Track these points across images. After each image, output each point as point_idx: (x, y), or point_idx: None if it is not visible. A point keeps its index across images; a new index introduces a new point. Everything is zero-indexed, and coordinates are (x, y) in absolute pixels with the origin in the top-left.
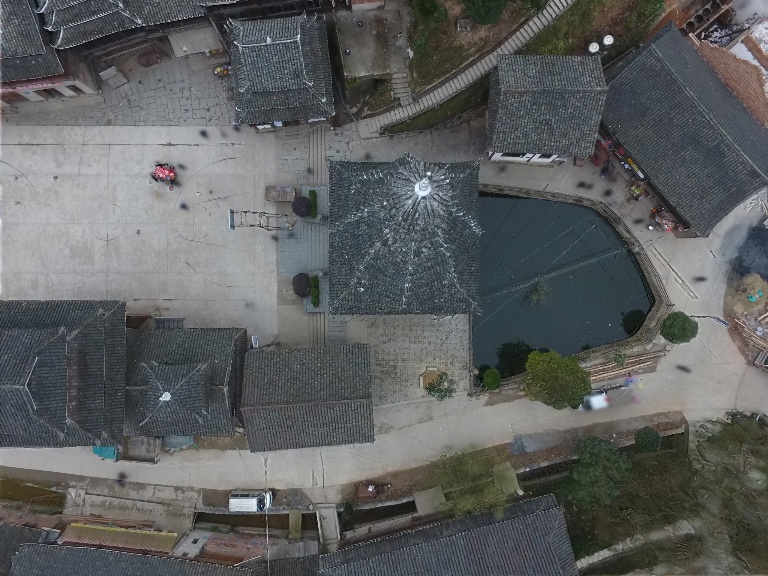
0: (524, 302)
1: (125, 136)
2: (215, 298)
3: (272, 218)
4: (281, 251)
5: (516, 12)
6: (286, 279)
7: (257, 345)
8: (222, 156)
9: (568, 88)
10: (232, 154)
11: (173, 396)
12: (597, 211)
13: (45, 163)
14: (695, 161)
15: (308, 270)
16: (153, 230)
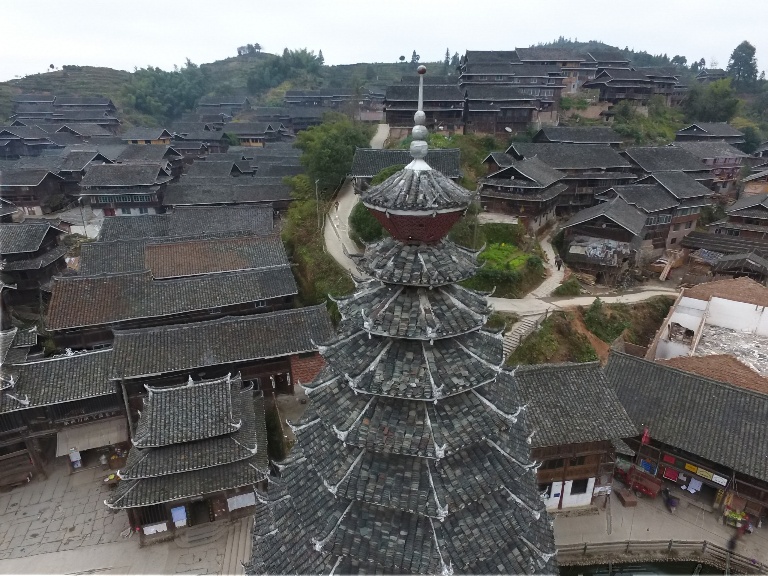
0: None
1: None
2: None
3: None
4: None
5: None
6: None
7: None
8: None
9: (556, 366)
10: None
11: None
12: (710, 566)
13: None
14: (767, 433)
15: None
16: None
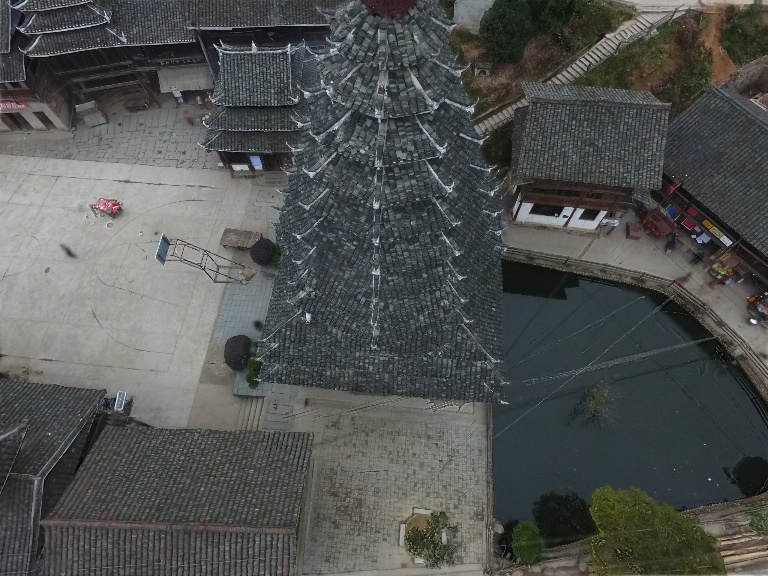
0: (573, 421)
1: (80, 170)
2: (113, 364)
3: (224, 268)
4: (224, 309)
5: (542, 64)
6: (221, 347)
7: (121, 408)
8: (184, 197)
9: None
10: (196, 196)
11: None
12: (667, 297)
13: None
14: None
15: (255, 337)
16: (67, 269)
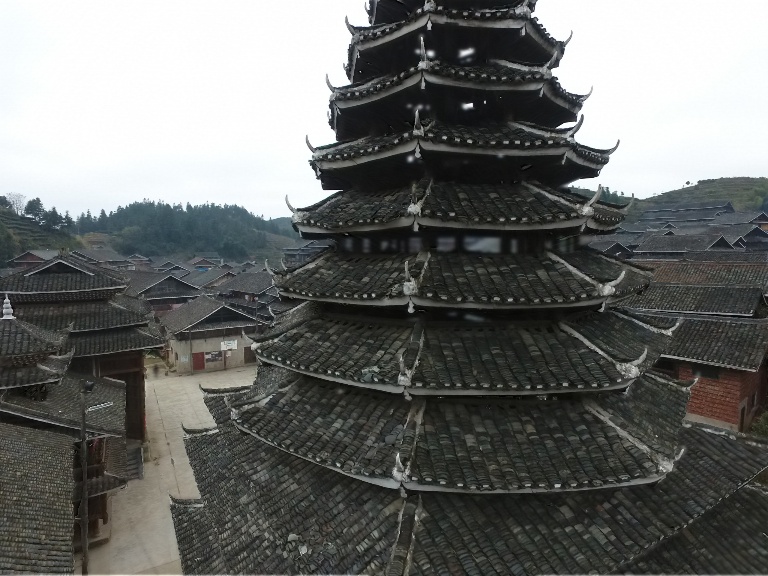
0: None
1: None
2: (183, 493)
3: None
4: None
5: None
6: None
7: (92, 410)
8: None
9: None
10: None
11: (6, 325)
12: None
13: None
14: None
15: None
16: None
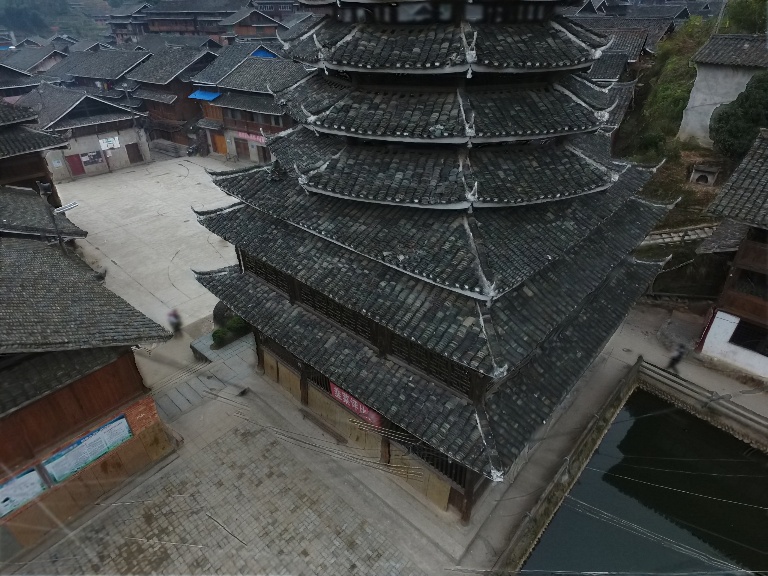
0: None
1: None
2: (145, 285)
3: None
4: None
5: None
6: None
7: (59, 211)
8: None
9: None
10: None
11: None
12: None
13: (207, 179)
14: None
15: None
16: (198, 225)
